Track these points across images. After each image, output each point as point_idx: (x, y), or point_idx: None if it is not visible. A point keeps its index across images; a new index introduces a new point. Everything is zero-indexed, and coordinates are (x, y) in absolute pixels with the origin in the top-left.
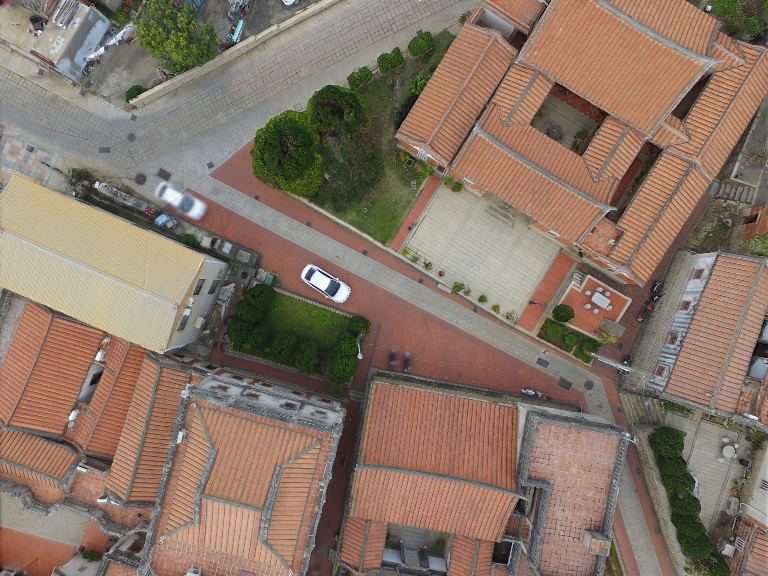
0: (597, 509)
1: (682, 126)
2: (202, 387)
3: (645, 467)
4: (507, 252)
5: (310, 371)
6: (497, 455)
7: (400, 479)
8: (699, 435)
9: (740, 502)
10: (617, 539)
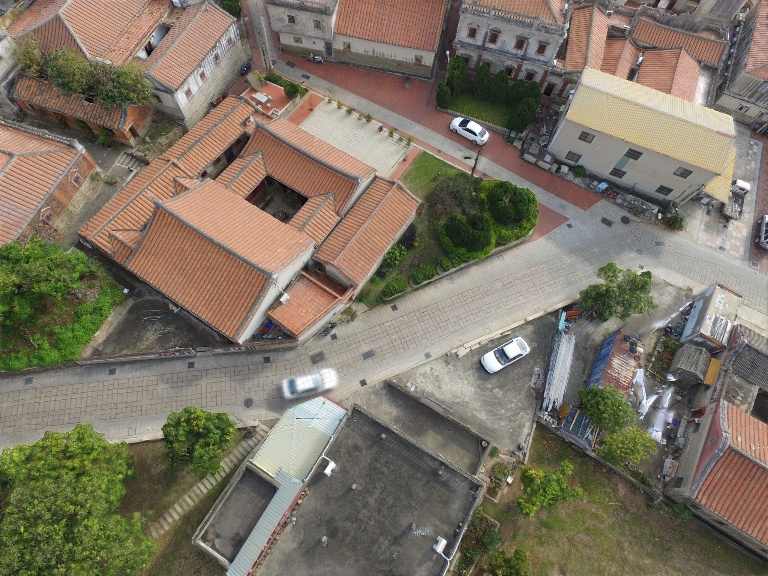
0: None
1: (178, 190)
2: (555, 43)
3: None
4: None
5: None
6: (353, 3)
7: None
8: None
9: None
10: None
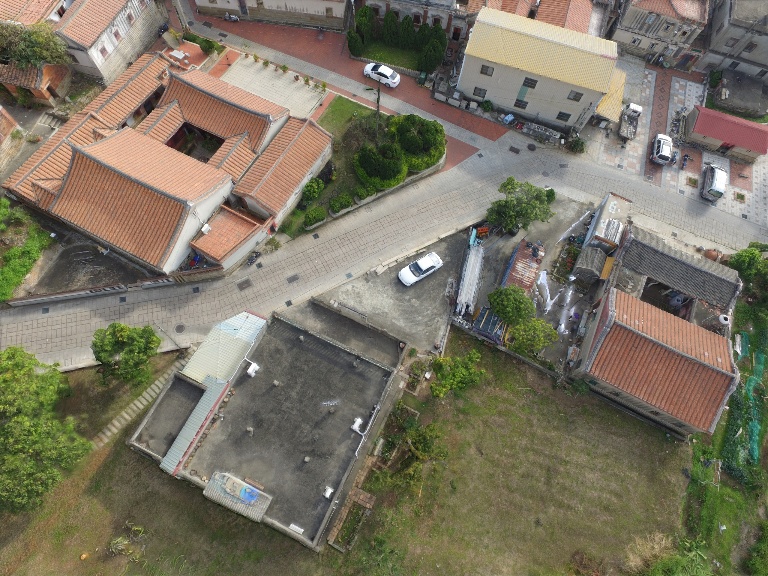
0: None
1: None
2: None
3: None
4: None
5: None
6: None
7: None
8: None
9: None
10: None
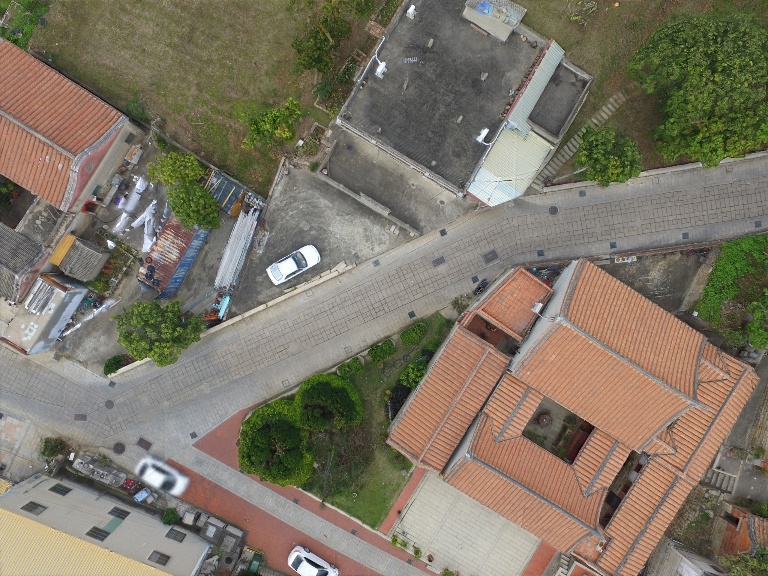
0: None
1: (669, 436)
2: None
3: None
4: (496, 534)
5: None
6: None
7: None
8: None
9: None
10: None
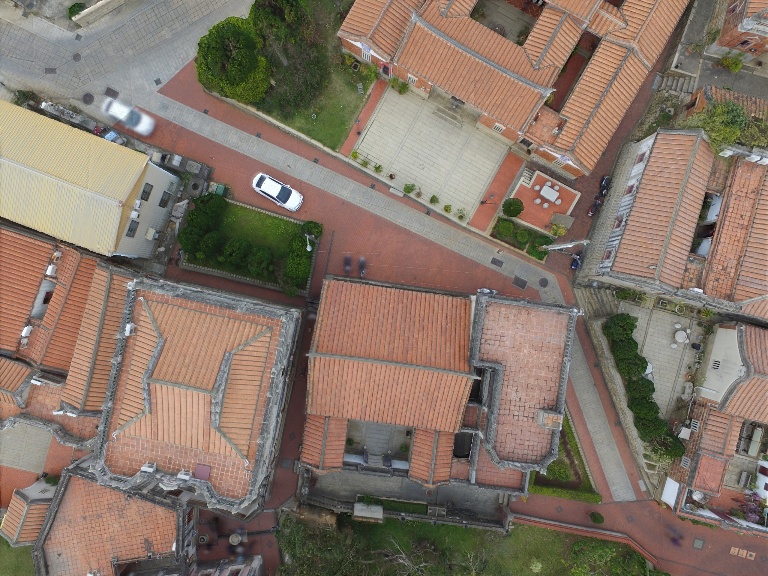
0: (550, 388)
1: (619, 13)
2: None
3: (601, 359)
4: (457, 153)
5: (263, 275)
6: (450, 342)
7: (354, 369)
8: (652, 323)
9: (694, 386)
10: (578, 433)
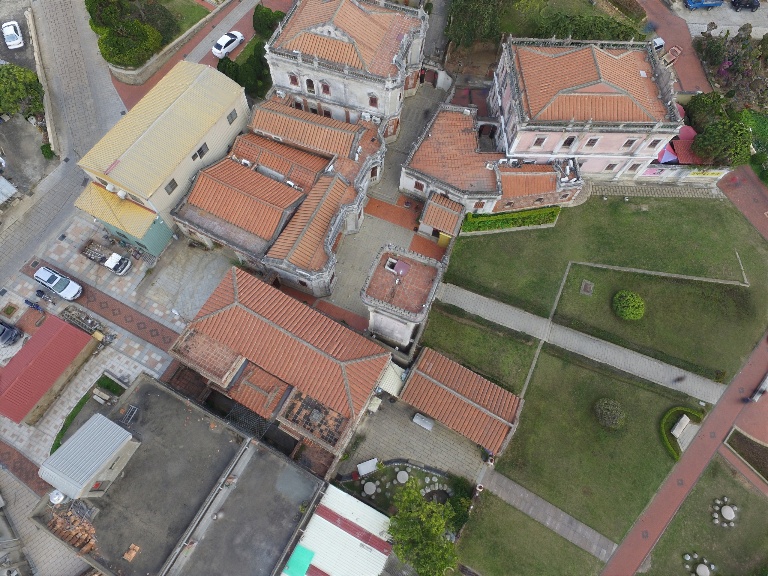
0: None
1: None
2: None
3: None
4: None
5: None
6: None
7: None
8: None
9: None
10: None
